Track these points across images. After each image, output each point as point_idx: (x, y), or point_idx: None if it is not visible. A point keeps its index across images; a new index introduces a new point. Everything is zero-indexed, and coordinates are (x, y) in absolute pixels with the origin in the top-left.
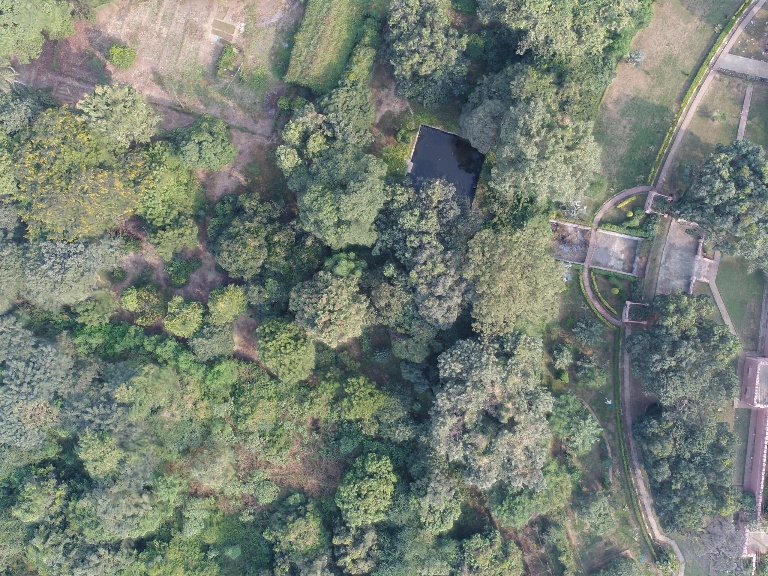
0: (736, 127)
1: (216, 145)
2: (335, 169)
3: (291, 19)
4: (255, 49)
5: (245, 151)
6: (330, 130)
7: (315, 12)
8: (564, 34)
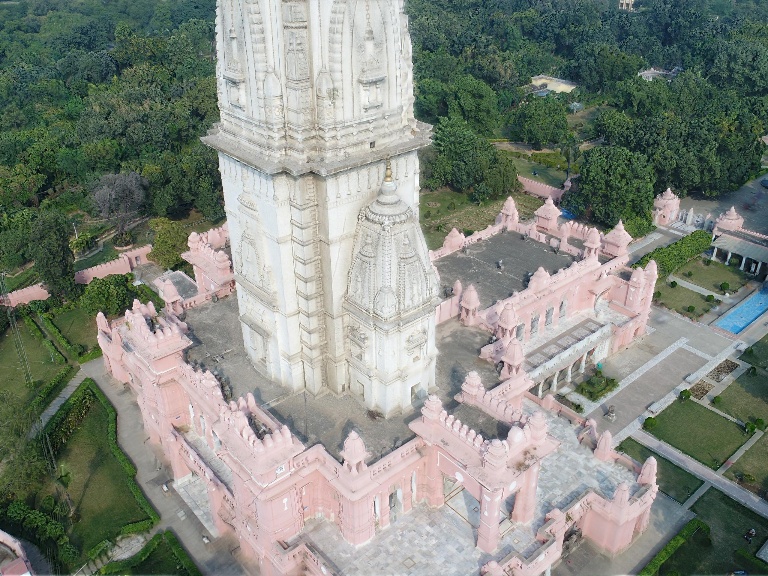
0: None
1: None
2: None
3: None
4: None
5: None
6: None
7: None
8: None
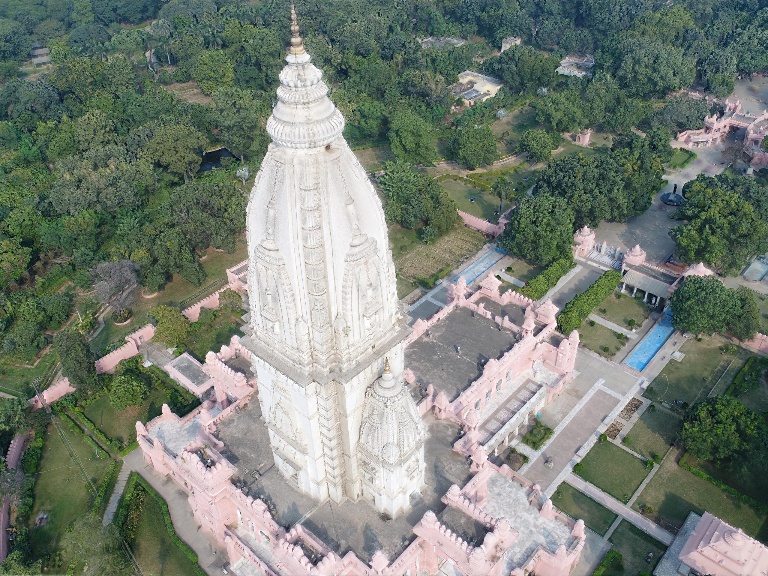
0: None
1: None
2: None
3: None
4: None
5: None
6: None
7: None
8: None
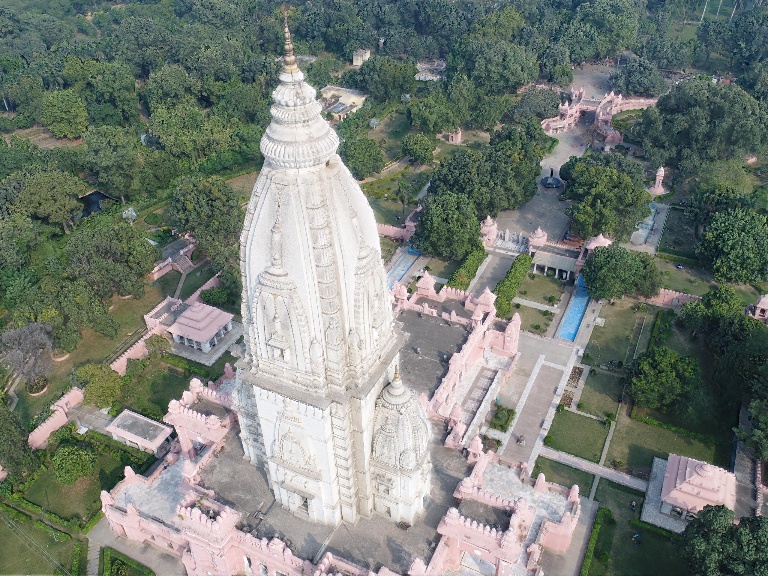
0: None
1: None
2: None
3: None
4: None
5: None
6: None
7: None
8: None
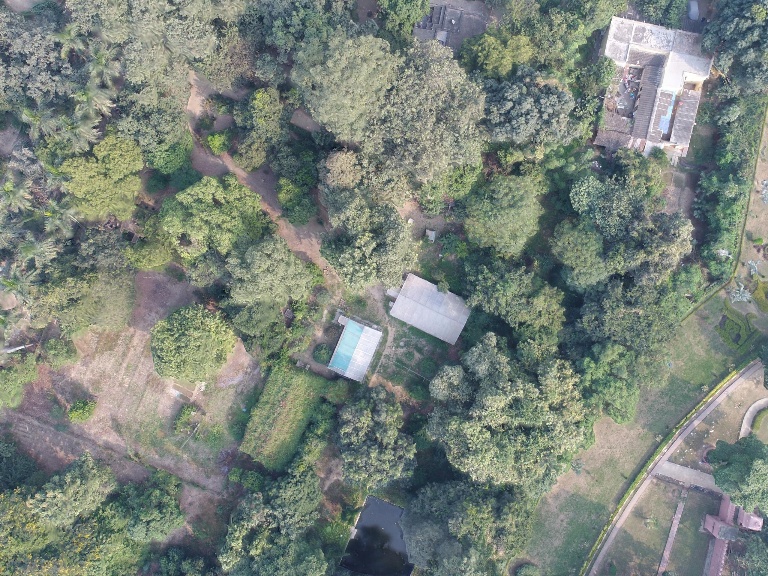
0: (668, 529)
1: (164, 523)
2: (274, 575)
3: (251, 383)
4: (214, 407)
5: (195, 503)
6: (275, 520)
7: (273, 392)
8: (505, 473)
